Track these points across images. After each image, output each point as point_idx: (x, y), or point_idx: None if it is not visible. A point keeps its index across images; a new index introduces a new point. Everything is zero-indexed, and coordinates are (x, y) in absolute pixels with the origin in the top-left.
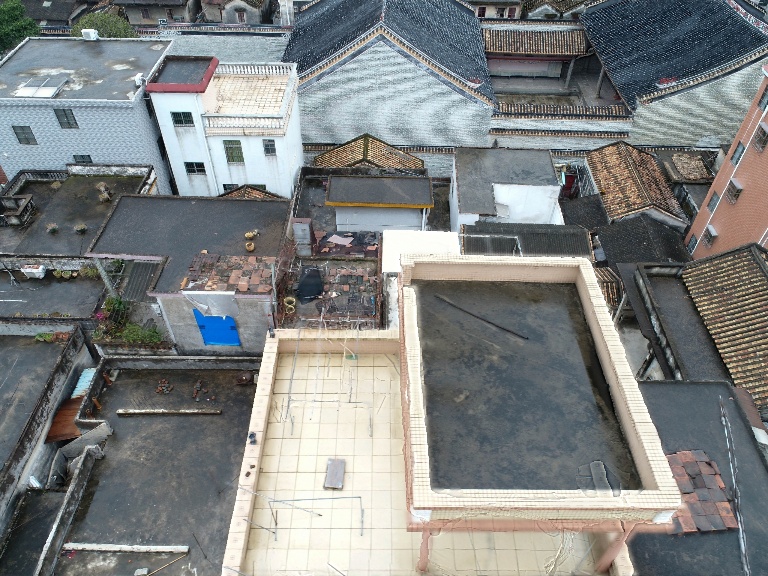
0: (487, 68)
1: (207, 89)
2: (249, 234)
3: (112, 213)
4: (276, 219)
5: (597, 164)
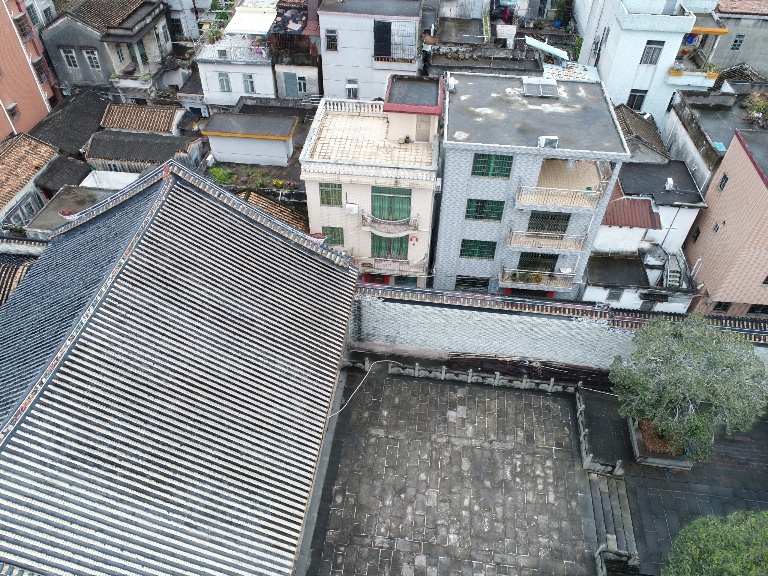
0: None
1: None
2: None
3: None
4: (328, 6)
5: (4, 194)
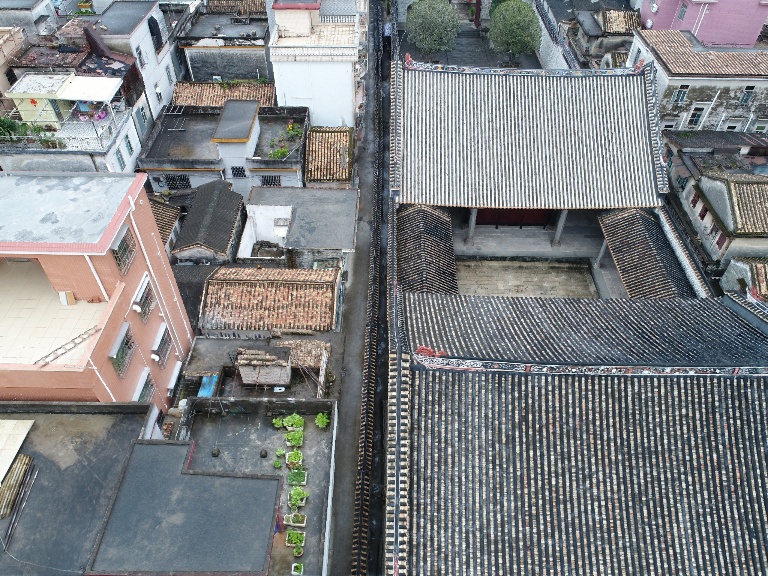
0: (514, 205)
1: (292, 15)
2: (104, 27)
3: (143, 1)
4: None
5: None
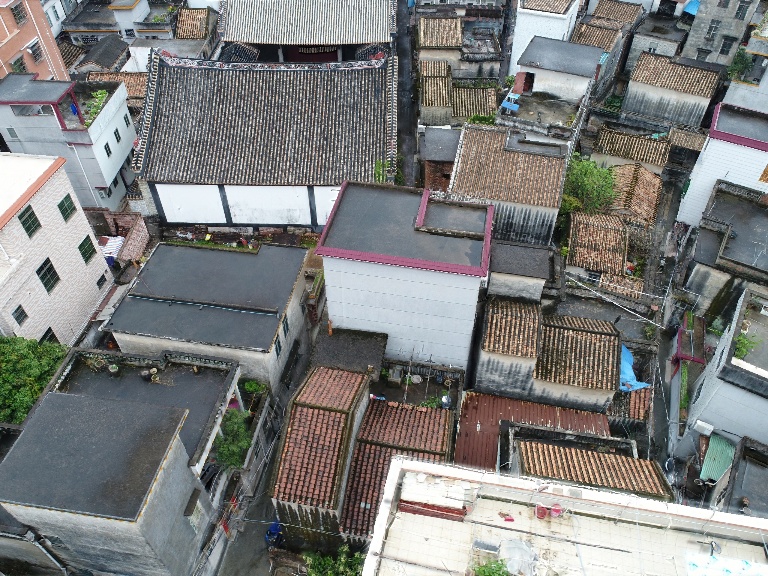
0: (298, 42)
1: None
2: None
3: None
4: None
5: None
